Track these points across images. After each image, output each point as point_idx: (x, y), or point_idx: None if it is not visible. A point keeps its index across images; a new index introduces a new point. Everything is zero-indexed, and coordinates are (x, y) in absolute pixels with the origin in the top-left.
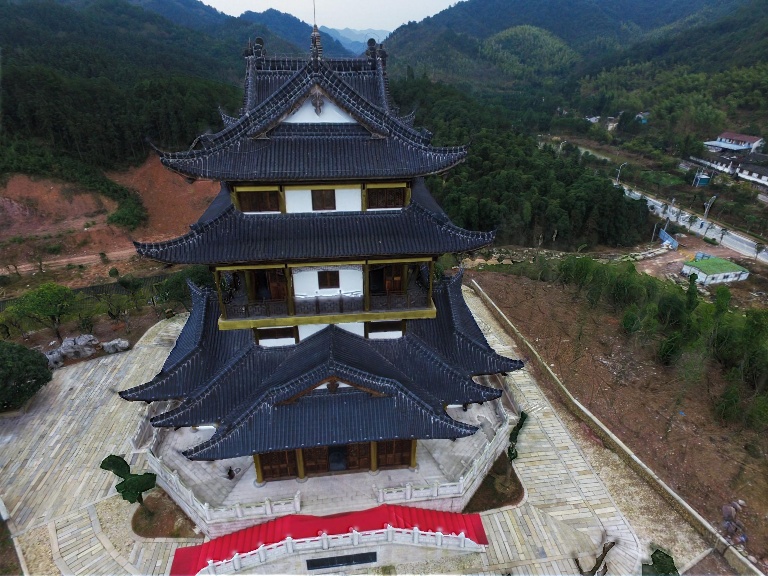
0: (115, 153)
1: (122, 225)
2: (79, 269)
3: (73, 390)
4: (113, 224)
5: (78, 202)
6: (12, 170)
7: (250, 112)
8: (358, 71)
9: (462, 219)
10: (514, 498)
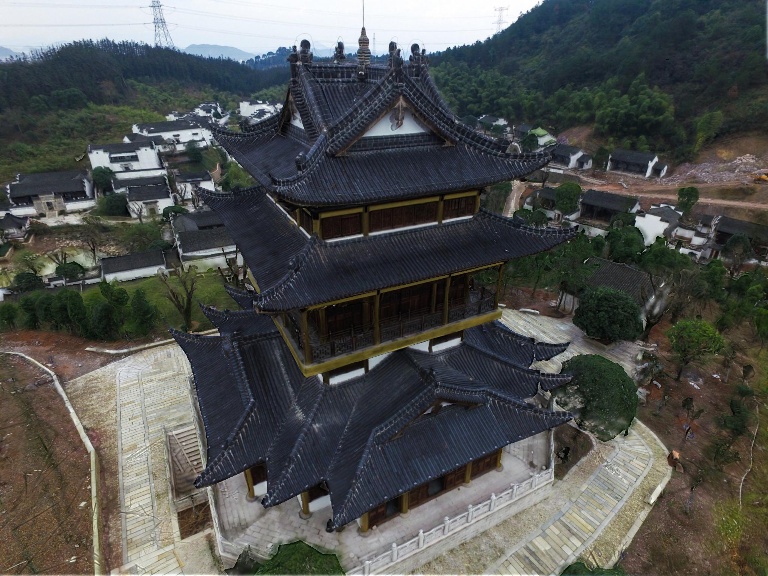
0: None
1: None
2: None
3: None
4: None
5: None
6: None
7: None
8: (321, 78)
9: None
10: None
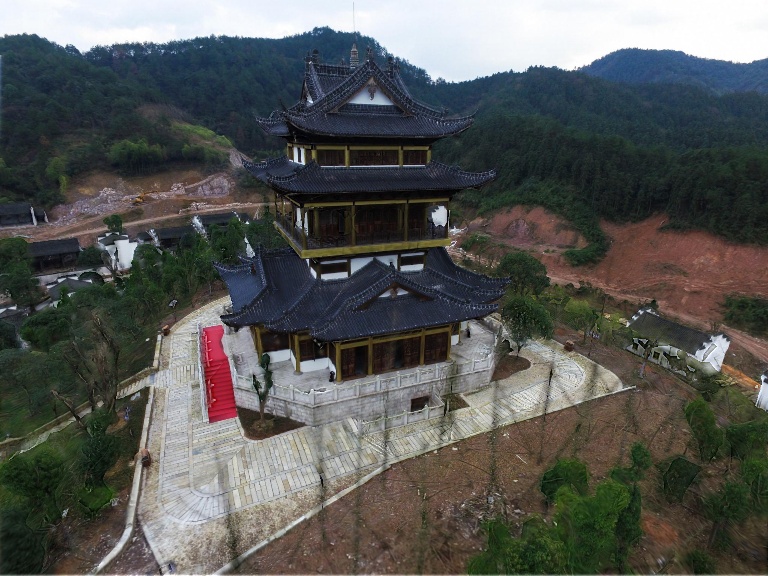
0: (623, 207)
1: (569, 259)
2: None
3: None
4: (564, 256)
5: (562, 235)
6: (538, 203)
7: None
8: None
9: None
10: (250, 432)
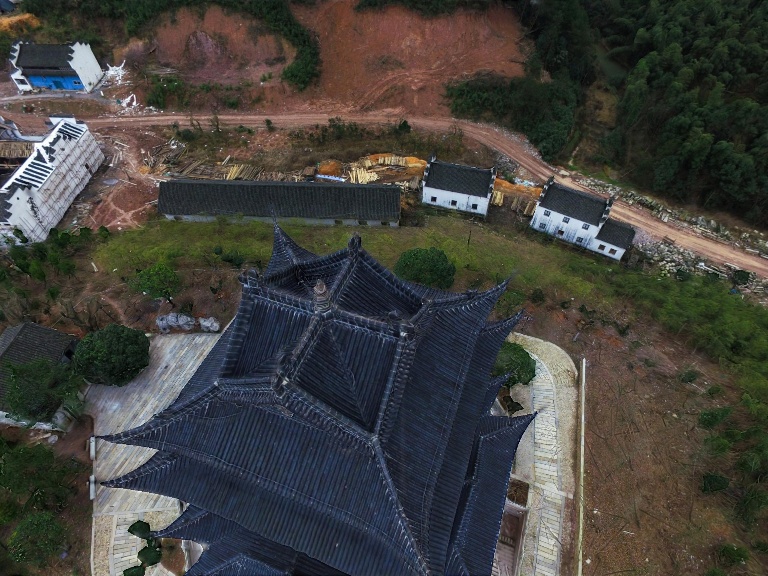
0: None
1: (294, 83)
2: (248, 134)
3: (167, 369)
4: (286, 81)
5: (262, 44)
6: None
7: (219, 382)
8: (376, 331)
9: (677, 161)
10: None
